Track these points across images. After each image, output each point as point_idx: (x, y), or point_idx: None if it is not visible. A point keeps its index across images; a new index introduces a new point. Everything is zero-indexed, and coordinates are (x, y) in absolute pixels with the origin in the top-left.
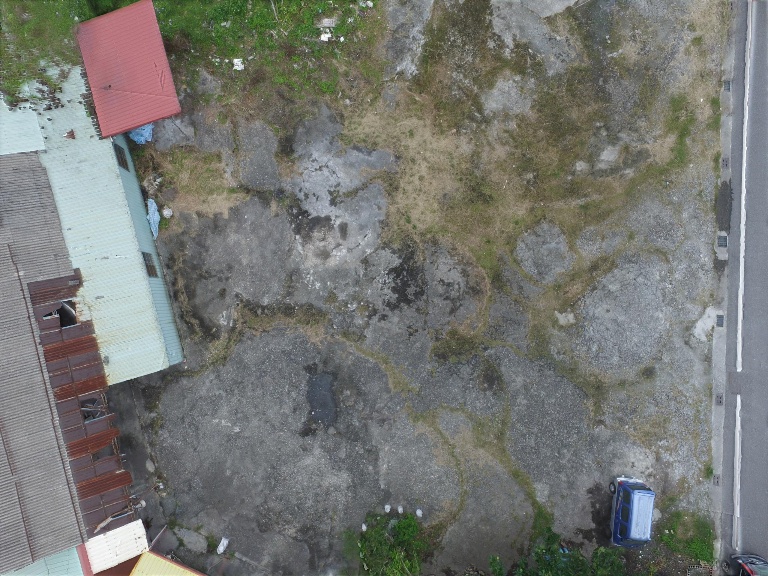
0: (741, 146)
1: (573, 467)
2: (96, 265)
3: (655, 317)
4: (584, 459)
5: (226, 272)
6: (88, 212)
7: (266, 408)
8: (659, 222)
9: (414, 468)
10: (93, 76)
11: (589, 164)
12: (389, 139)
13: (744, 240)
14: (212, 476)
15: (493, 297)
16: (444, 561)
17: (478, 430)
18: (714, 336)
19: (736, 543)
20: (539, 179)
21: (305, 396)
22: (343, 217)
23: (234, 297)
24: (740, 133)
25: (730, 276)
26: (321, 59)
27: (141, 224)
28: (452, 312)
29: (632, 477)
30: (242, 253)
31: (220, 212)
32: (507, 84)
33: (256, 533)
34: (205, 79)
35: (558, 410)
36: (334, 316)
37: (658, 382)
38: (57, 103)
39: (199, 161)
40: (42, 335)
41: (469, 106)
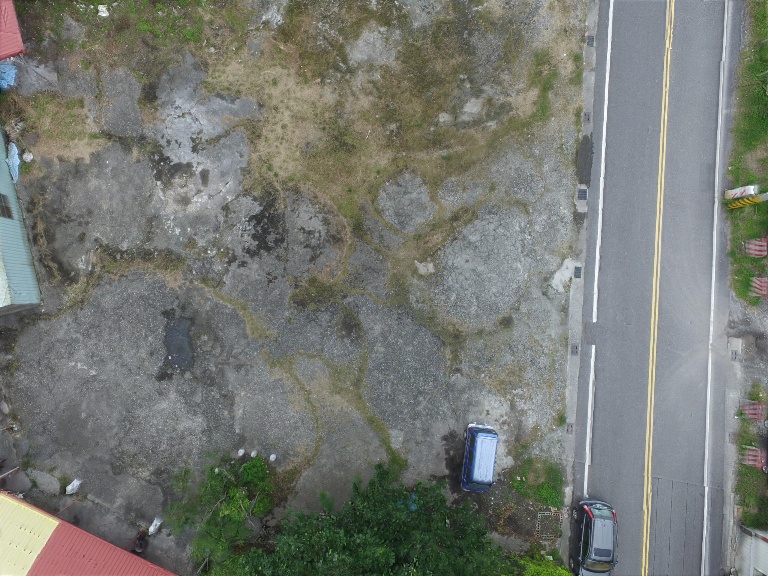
0: (603, 100)
1: (428, 414)
2: None
3: (514, 268)
4: (439, 406)
5: (86, 217)
6: None
7: (123, 352)
8: (520, 174)
9: (270, 413)
10: None
11: (452, 116)
12: (253, 87)
13: (603, 193)
14: (67, 419)
15: (353, 245)
16: (297, 506)
17: (334, 376)
18: (571, 287)
19: (586, 490)
20: (402, 130)
21: (162, 341)
22: (205, 164)
23: (93, 241)
24: (602, 88)
25: (589, 228)
26: (186, 7)
27: None
28: (312, 260)
29: (484, 424)
30: (103, 198)
31: (81, 157)
32: (372, 35)
33: (109, 476)
34: (69, 24)
35: (415, 358)
36: (194, 262)
37: (515, 332)
38: None
39: (61, 106)
40: None
41: (334, 56)
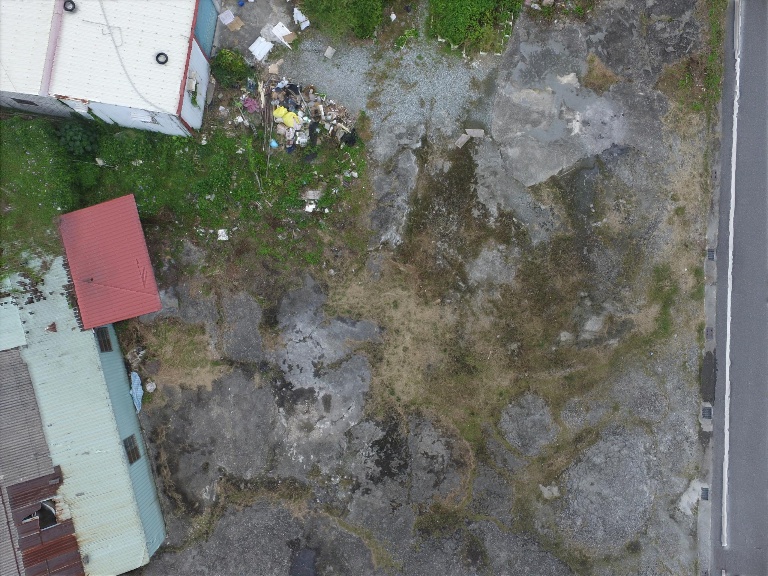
0: (725, 316)
1: None
2: (76, 461)
3: (640, 490)
4: None
5: (209, 445)
6: (69, 407)
7: None
8: (643, 393)
9: None
10: (75, 268)
11: (573, 334)
12: (373, 310)
13: (729, 412)
14: None
15: (477, 470)
16: None
17: None
18: (699, 509)
19: None
20: (523, 350)
21: (288, 572)
22: (327, 389)
23: (217, 471)
24: (724, 303)
25: (715, 448)
26: (305, 229)
27: (123, 406)
28: (436, 485)
29: None
30: (225, 426)
31: (204, 384)
32: (491, 253)
33: None
34: (189, 250)
35: None
36: (317, 490)
37: (643, 557)
38: (39, 296)
39: (183, 333)
40: (21, 540)
41: (453, 276)
